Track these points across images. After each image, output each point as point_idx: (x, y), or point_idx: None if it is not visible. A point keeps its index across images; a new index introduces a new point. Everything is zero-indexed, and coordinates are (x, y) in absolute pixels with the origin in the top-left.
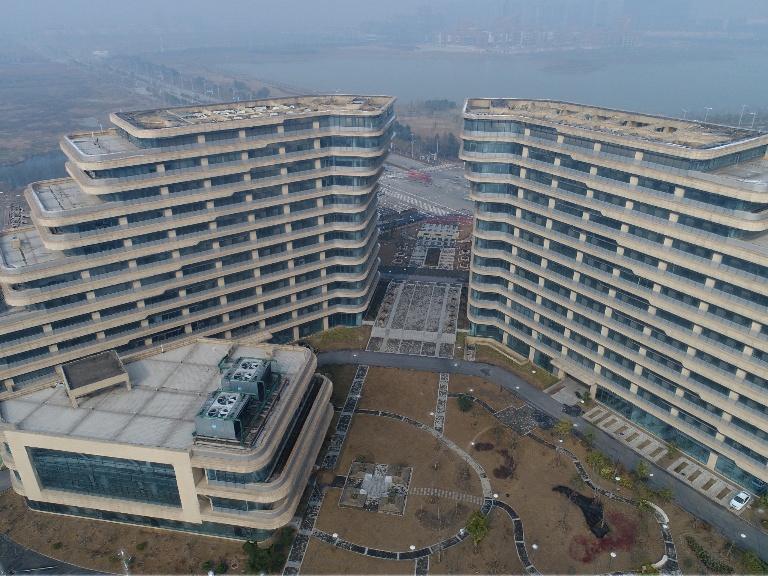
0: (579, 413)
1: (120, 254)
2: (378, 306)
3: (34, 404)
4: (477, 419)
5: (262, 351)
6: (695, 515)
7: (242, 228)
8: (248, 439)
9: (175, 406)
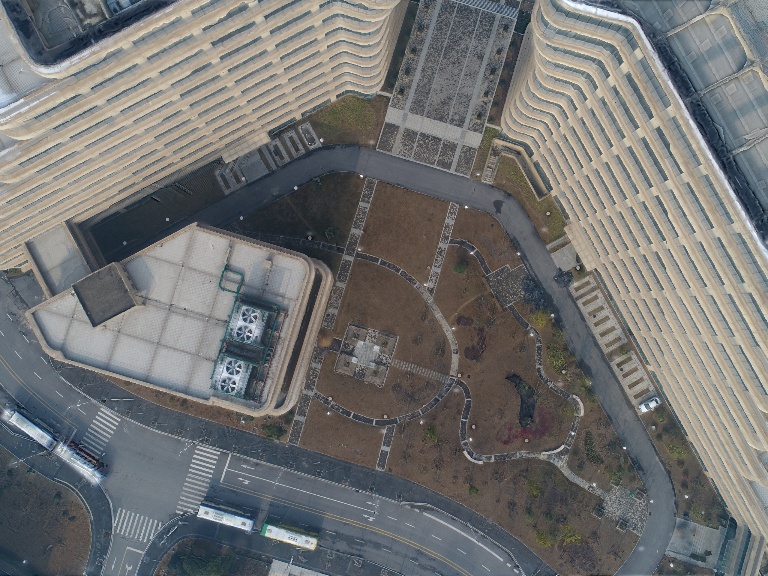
0: (568, 284)
1: (76, 160)
2: (400, 61)
3: (65, 319)
4: (468, 284)
5: (260, 255)
6: (606, 412)
7: (214, 87)
8: (256, 395)
9: (189, 336)
